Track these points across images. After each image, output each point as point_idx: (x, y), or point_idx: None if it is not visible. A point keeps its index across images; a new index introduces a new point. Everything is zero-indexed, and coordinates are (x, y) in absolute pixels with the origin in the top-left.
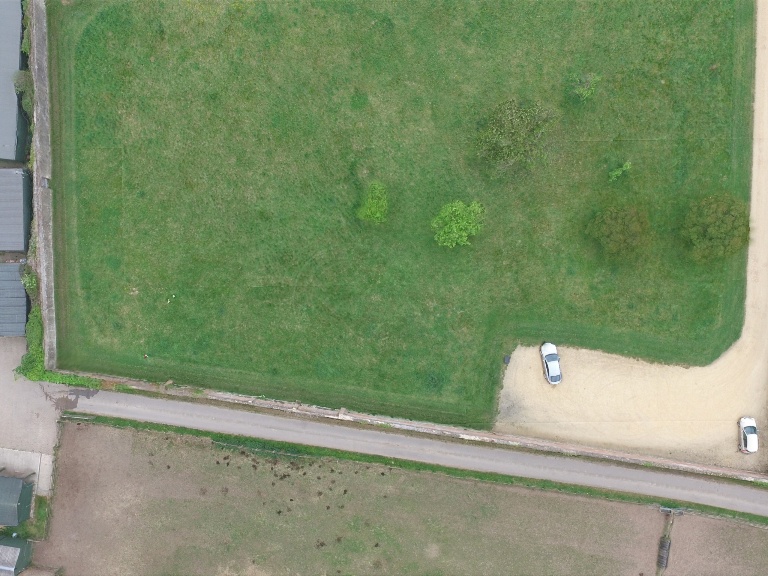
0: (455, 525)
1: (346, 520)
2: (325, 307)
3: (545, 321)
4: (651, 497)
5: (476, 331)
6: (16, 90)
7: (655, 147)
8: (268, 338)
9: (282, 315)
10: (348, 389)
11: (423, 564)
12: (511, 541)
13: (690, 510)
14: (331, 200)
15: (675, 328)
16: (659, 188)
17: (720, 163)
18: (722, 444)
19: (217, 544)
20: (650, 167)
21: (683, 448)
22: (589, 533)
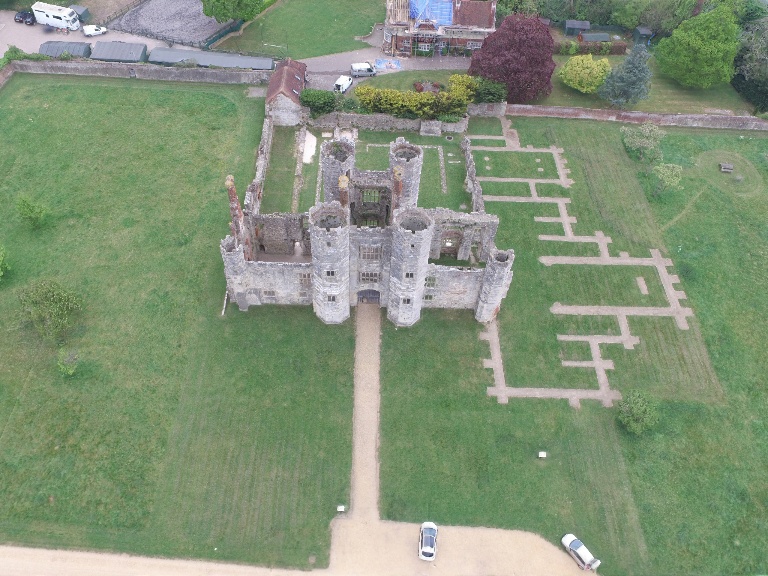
0: None
1: None
2: None
3: None
4: None
5: None
6: (186, 60)
7: None
8: None
9: None
10: None
11: None
12: None
13: None
14: (59, 201)
15: None
16: None
17: None
18: None
19: None
20: None
21: None
22: None
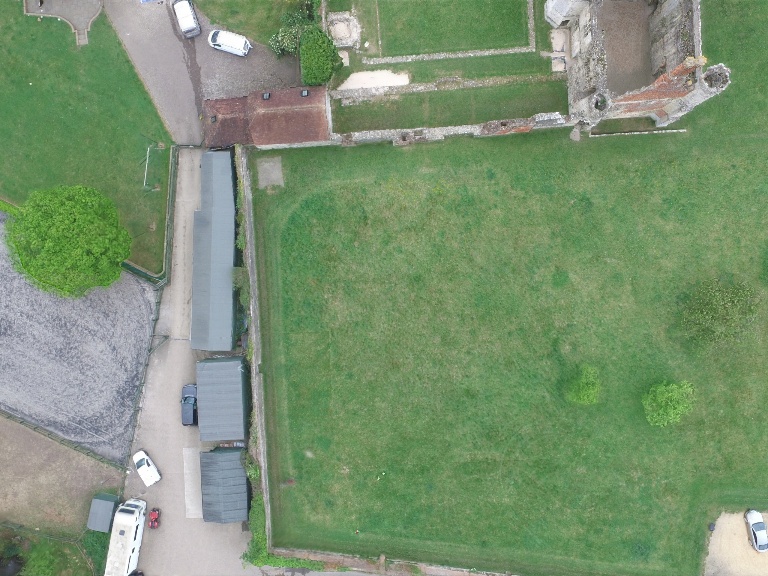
0: None
1: None
2: (532, 480)
3: (749, 488)
4: None
5: (680, 500)
6: (234, 287)
7: None
8: (477, 512)
9: (490, 489)
10: (556, 559)
11: None
12: None
13: None
14: (535, 376)
15: None
16: None
17: None
18: None
19: None
20: None
21: None
22: None
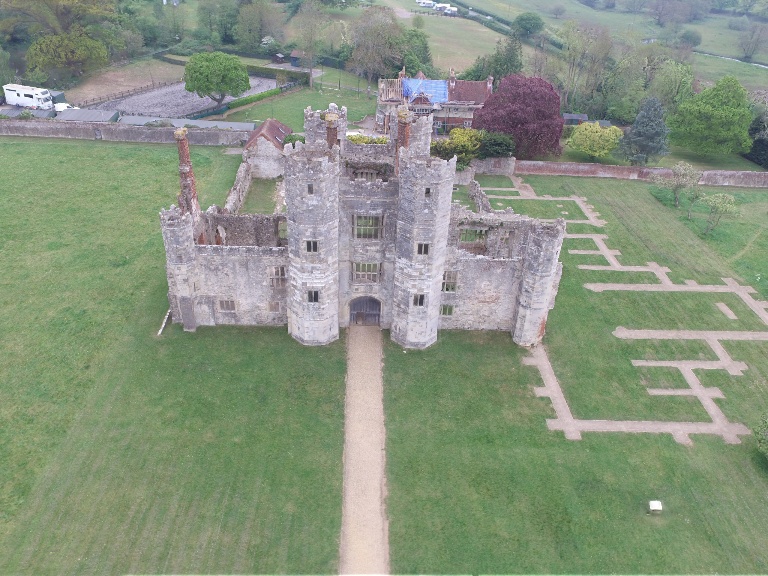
0: None
1: None
2: None
3: None
4: None
5: None
6: (160, 120)
7: None
8: None
9: None
10: None
11: None
12: None
13: None
14: None
15: None
16: None
17: None
18: None
19: None
20: None
21: None
22: None
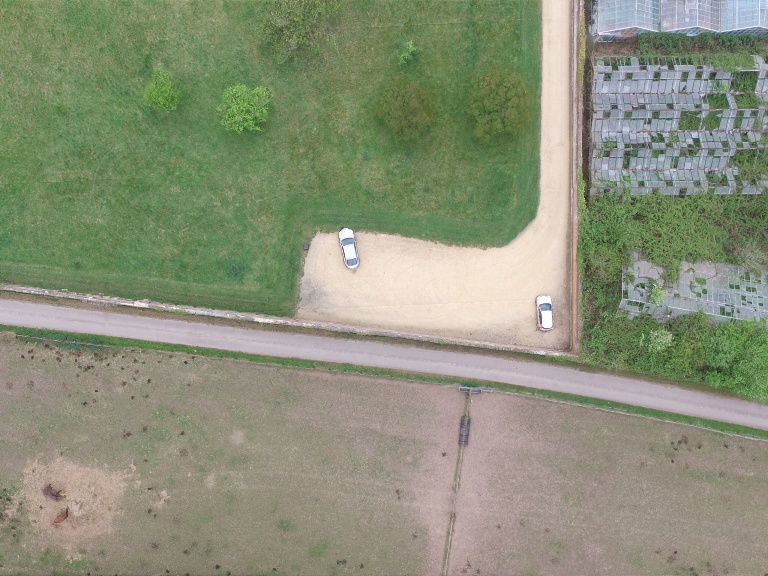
0: (259, 411)
1: (151, 409)
2: (125, 200)
3: (343, 207)
4: (451, 377)
5: (275, 219)
6: None
7: (446, 31)
8: (69, 232)
9: (83, 209)
10: (151, 281)
11: (229, 451)
12: (315, 425)
13: (490, 389)
14: (127, 93)
15: (471, 210)
16: (451, 71)
17: (510, 45)
18: (521, 323)
19: (25, 437)
20: (441, 51)
21: (483, 329)
22: (391, 415)
